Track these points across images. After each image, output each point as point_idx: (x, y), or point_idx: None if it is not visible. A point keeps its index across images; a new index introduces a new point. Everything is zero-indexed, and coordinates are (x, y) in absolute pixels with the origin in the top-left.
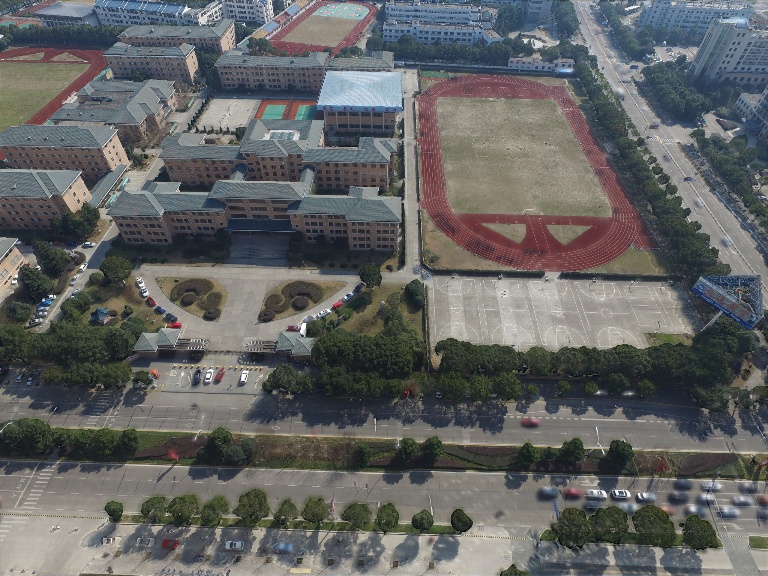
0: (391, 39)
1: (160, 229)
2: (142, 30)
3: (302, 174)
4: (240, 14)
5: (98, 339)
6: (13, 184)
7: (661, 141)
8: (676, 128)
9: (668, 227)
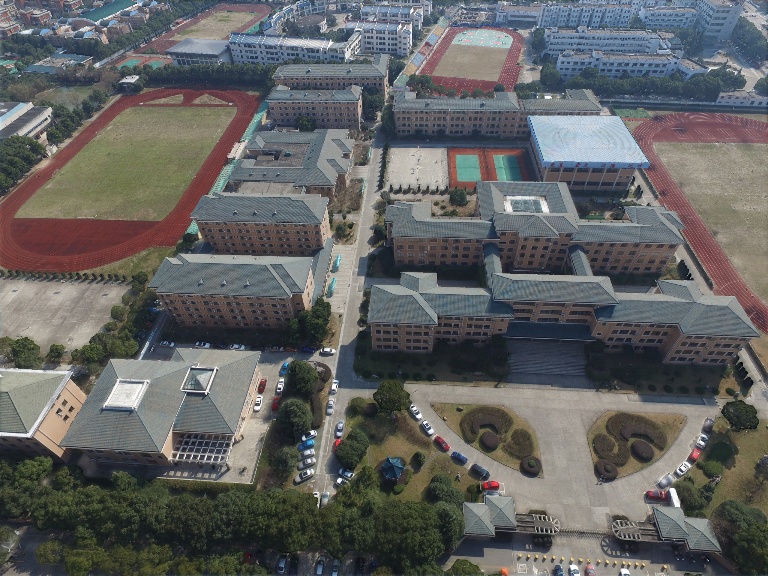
0: (567, 72)
1: (425, 337)
2: (298, 70)
3: (574, 258)
4: (378, 46)
5: (433, 526)
6: (245, 280)
7: None
8: None
9: None
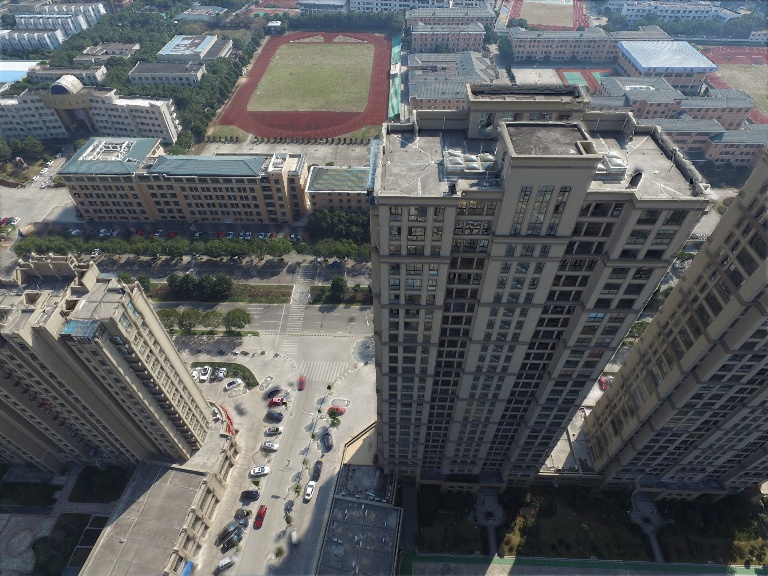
0: (631, 18)
1: None
2: (425, 12)
3: (683, 118)
4: (467, 1)
5: None
6: None
7: None
8: None
9: None
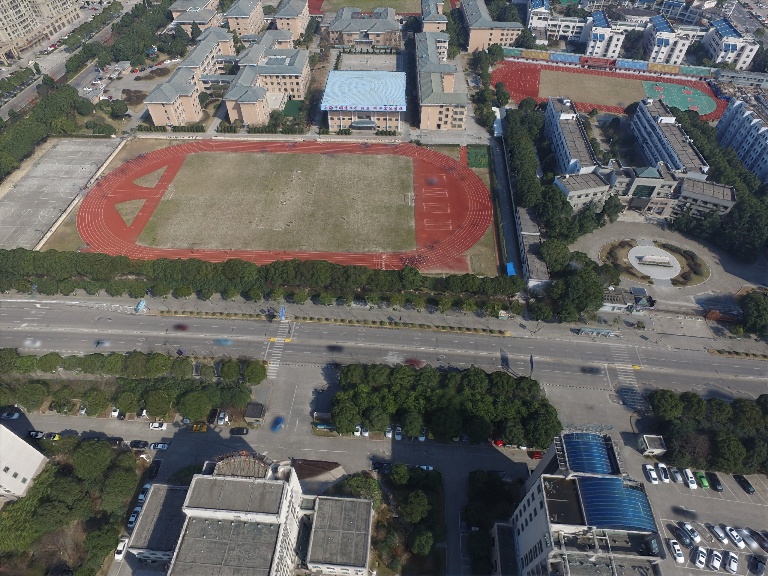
0: (547, 116)
1: None
2: None
3: None
4: None
5: None
6: None
7: (274, 339)
8: (315, 379)
9: (68, 251)
